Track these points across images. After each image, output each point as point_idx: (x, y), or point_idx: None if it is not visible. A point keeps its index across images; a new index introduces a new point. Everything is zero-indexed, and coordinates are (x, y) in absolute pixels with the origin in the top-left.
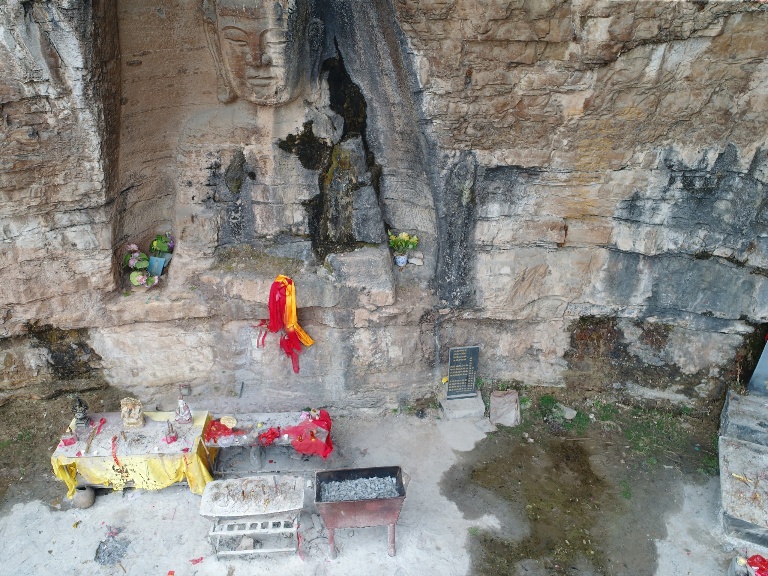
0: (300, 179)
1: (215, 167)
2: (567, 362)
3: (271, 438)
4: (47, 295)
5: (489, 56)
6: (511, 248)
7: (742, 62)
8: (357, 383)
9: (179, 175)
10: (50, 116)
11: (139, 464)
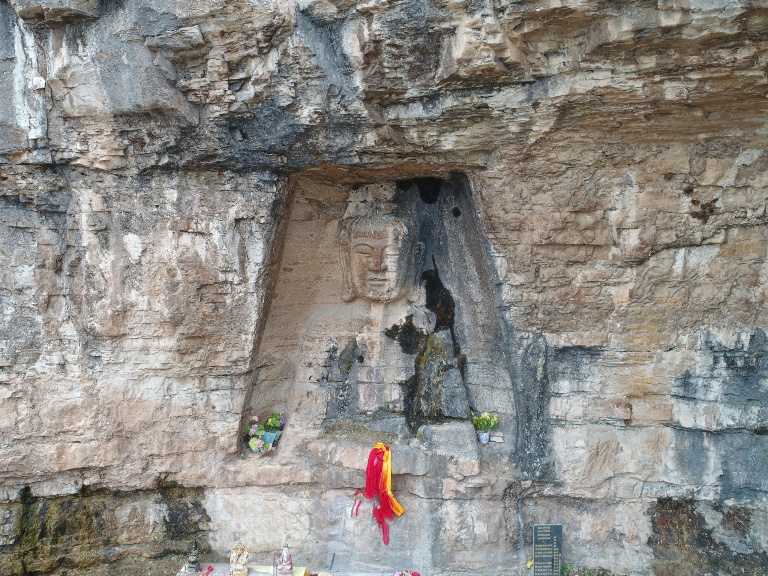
0: (399, 362)
1: (332, 351)
2: (652, 550)
3: None
4: (182, 450)
5: (552, 256)
6: (583, 424)
7: (748, 263)
8: (444, 560)
9: (302, 357)
10: (229, 297)
11: None
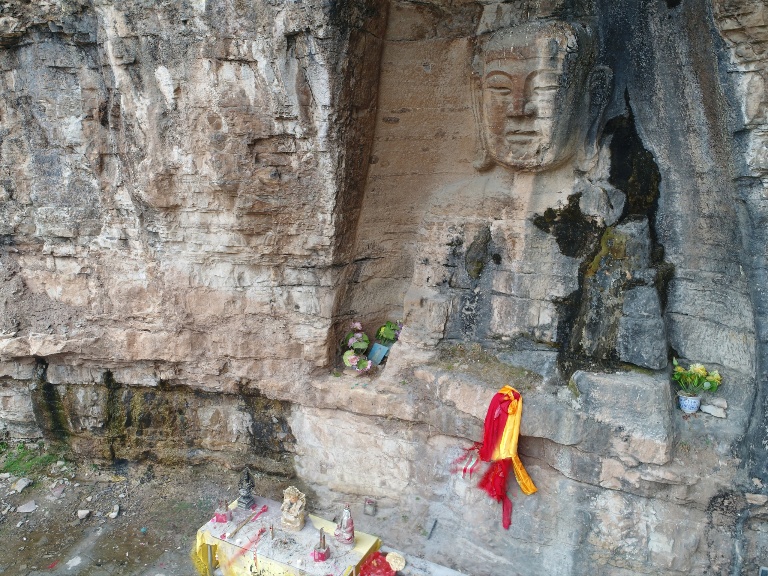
0: (555, 268)
1: (456, 244)
2: None
3: None
4: (261, 355)
5: None
6: None
7: None
8: (591, 574)
9: (417, 251)
10: (294, 158)
11: (277, 575)
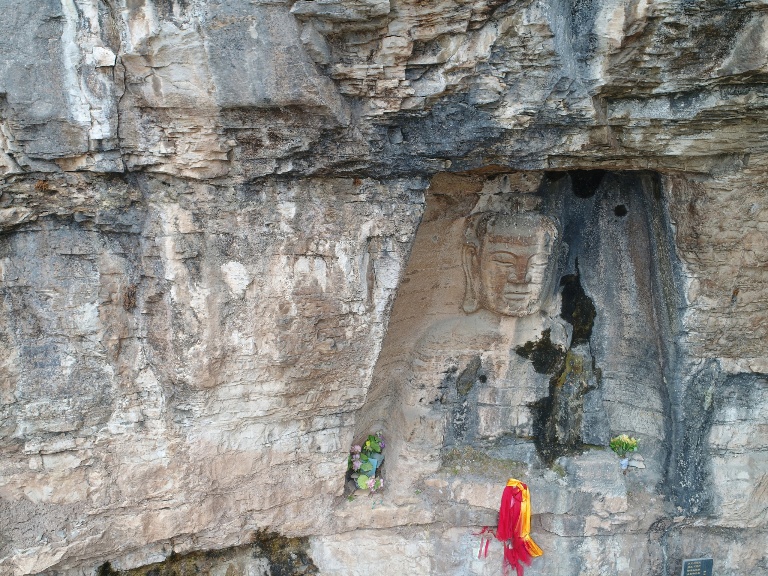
0: (530, 382)
1: (451, 371)
2: None
3: None
4: (286, 500)
5: (759, 279)
6: (744, 452)
7: None
8: None
9: (413, 378)
10: (349, 329)
11: None
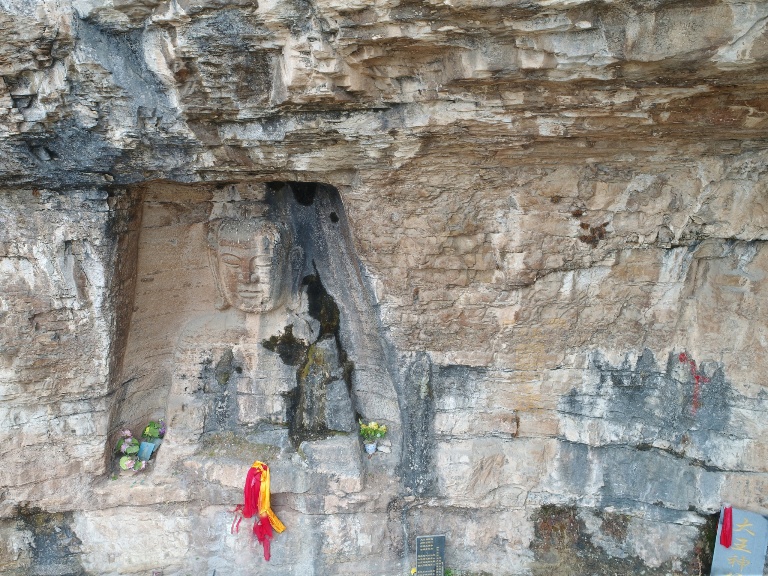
0: (280, 373)
1: (207, 363)
2: (534, 553)
3: None
4: (41, 478)
5: (431, 280)
6: (469, 438)
7: (640, 284)
8: (326, 573)
9: (175, 369)
10: (71, 323)
11: None
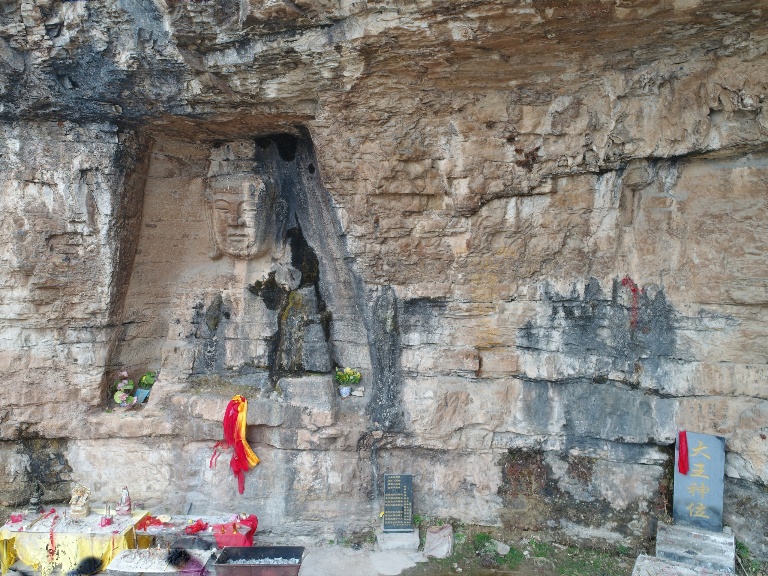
0: (264, 318)
1: (199, 307)
2: (502, 499)
3: (196, 528)
4: (42, 401)
5: (388, 207)
6: (434, 375)
7: (579, 212)
8: (297, 509)
9: (171, 314)
10: (81, 249)
11: (71, 544)
